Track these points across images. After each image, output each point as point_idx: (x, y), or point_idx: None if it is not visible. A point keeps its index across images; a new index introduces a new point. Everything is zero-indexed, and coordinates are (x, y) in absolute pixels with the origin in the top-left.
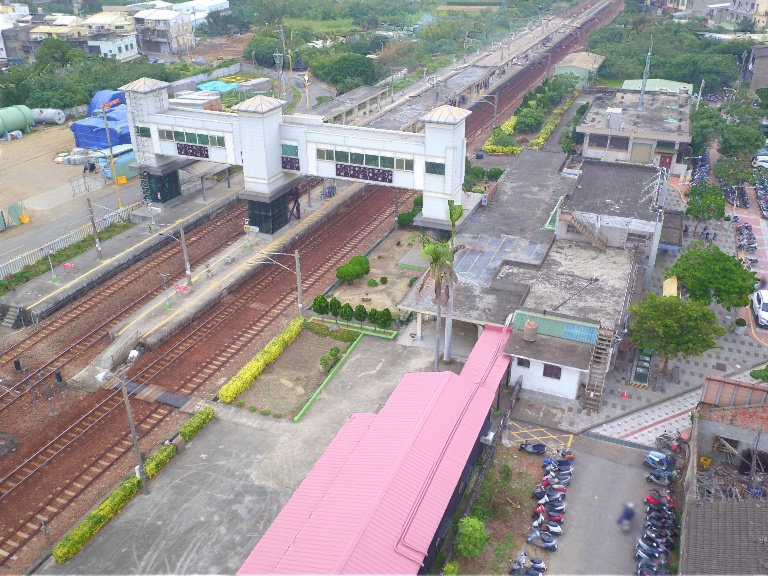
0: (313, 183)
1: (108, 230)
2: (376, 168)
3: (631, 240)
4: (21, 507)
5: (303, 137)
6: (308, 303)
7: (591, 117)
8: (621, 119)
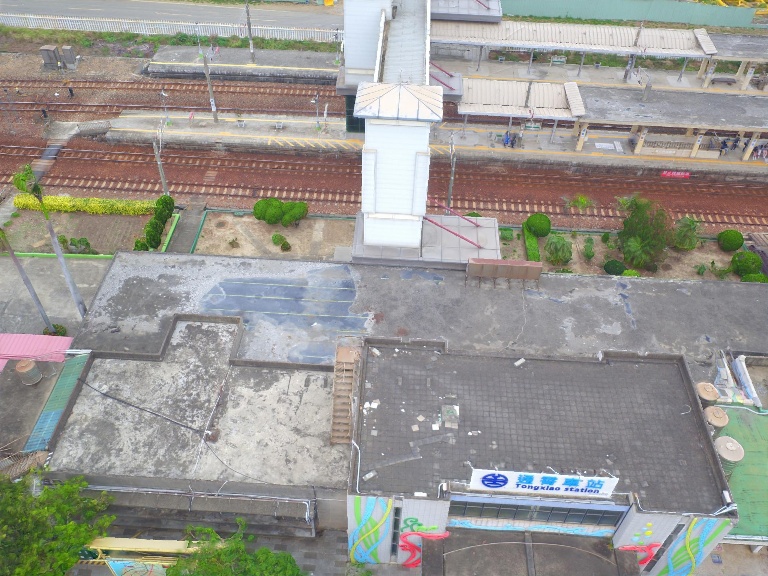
0: (568, 123)
1: (332, 45)
2: None
3: None
4: None
5: None
6: (225, 206)
7: None
8: None
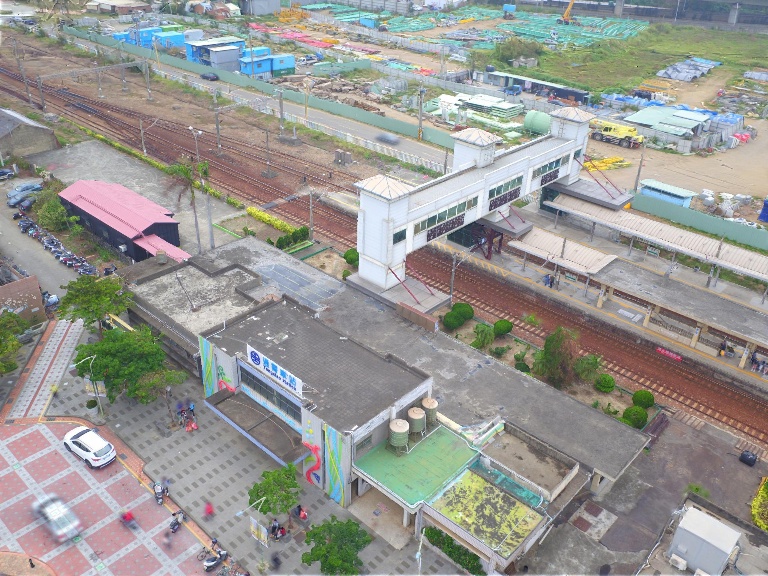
0: (625, 295)
1: None
2: None
3: None
4: (227, 179)
5: None
6: (343, 251)
7: None
8: None
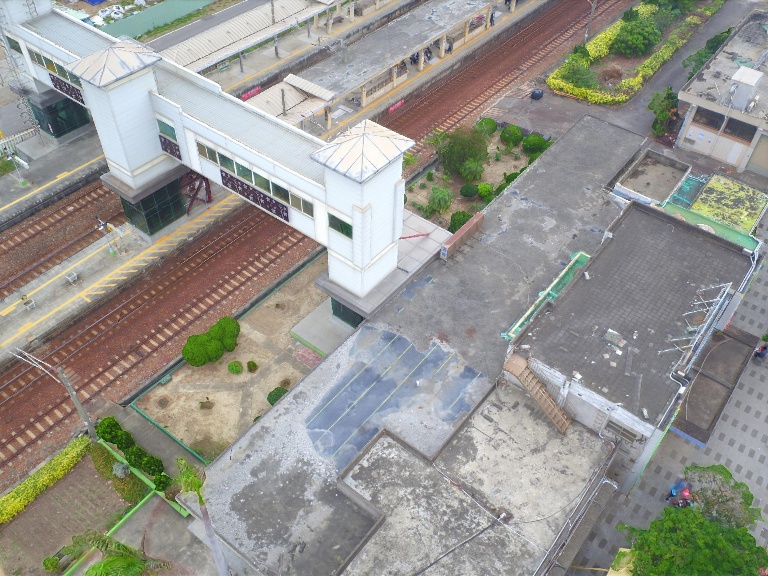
0: None
1: None
2: (268, 195)
3: (613, 428)
4: None
5: (178, 119)
6: (134, 387)
7: (719, 65)
8: (766, 78)
